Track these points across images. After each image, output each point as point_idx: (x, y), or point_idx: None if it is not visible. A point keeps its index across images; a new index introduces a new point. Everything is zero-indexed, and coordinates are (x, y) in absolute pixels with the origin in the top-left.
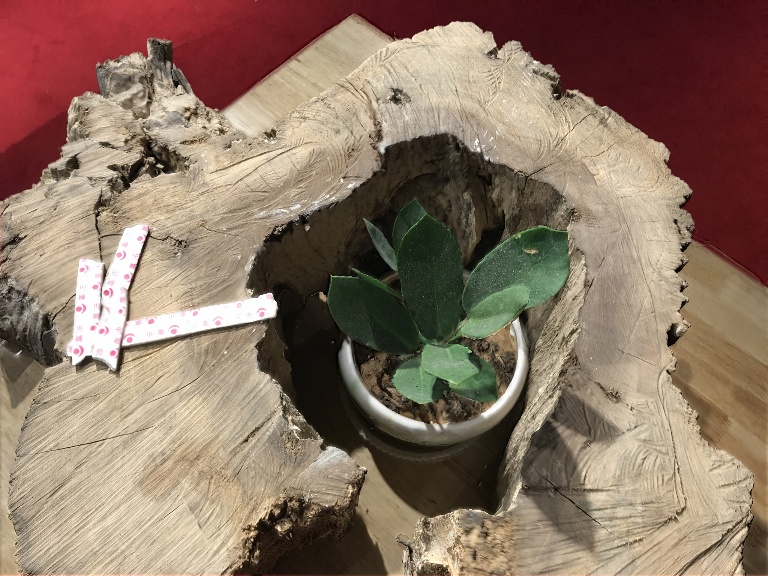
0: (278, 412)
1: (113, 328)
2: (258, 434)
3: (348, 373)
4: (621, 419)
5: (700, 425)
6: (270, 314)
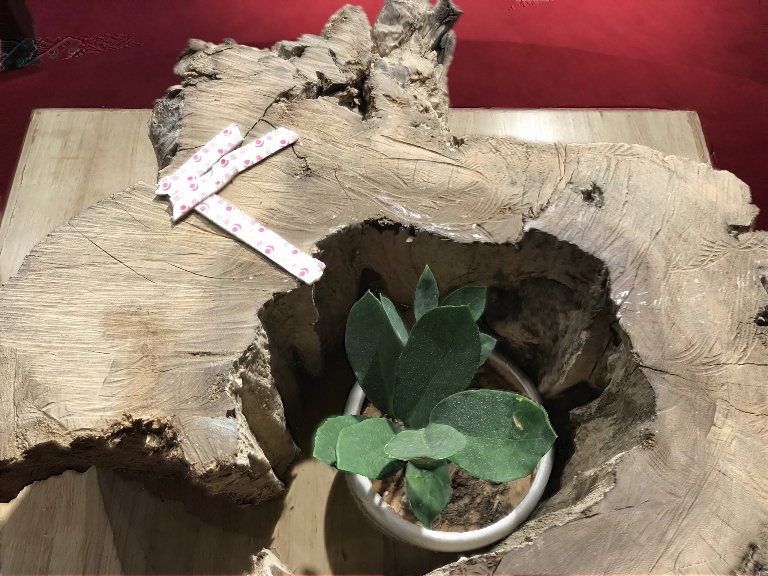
0: (235, 356)
1: (201, 190)
2: (206, 358)
3: (357, 387)
4: None
5: None
6: (308, 279)
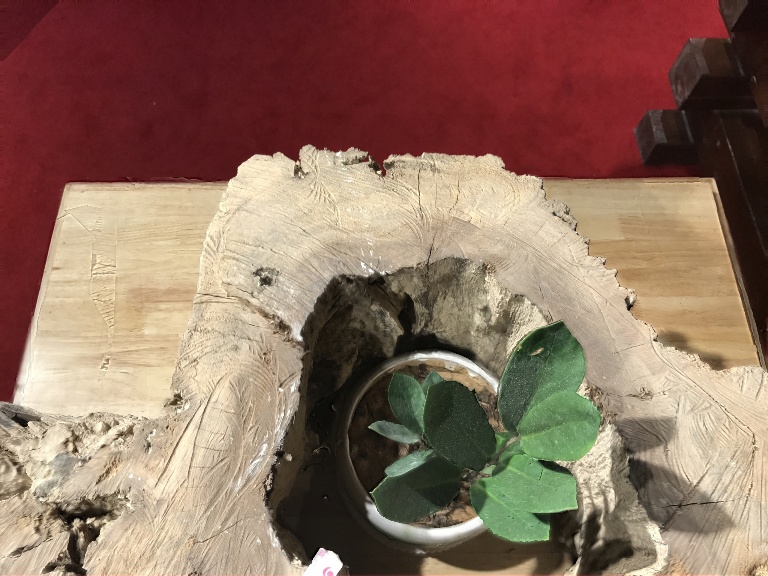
0: None
1: None
2: None
3: (393, 528)
4: (666, 408)
5: None
6: (337, 567)
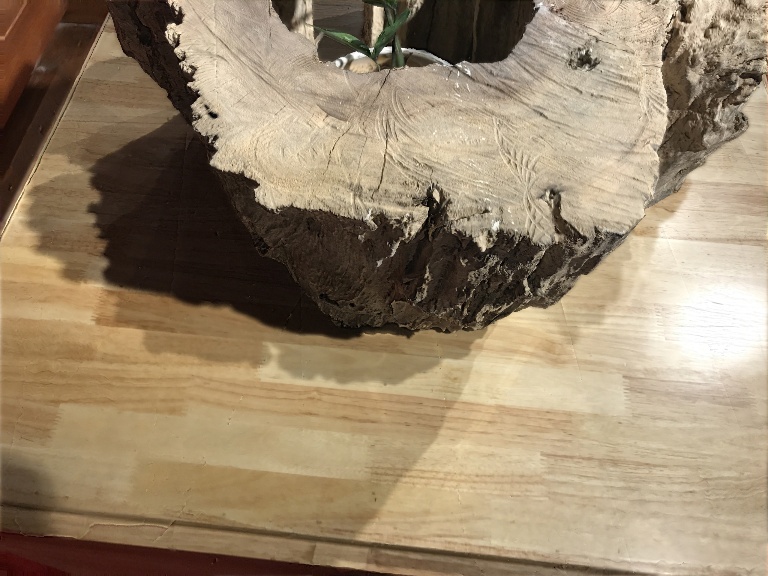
0: None
1: None
2: None
3: None
4: None
5: (122, 299)
6: None
